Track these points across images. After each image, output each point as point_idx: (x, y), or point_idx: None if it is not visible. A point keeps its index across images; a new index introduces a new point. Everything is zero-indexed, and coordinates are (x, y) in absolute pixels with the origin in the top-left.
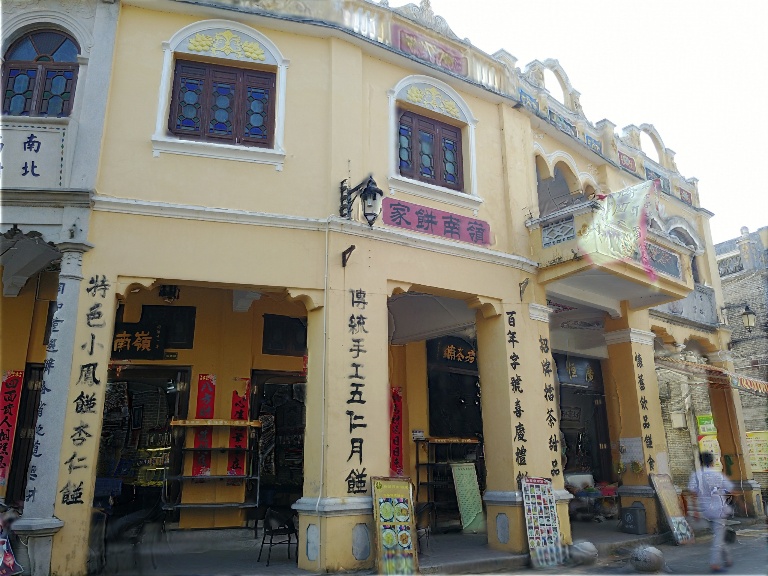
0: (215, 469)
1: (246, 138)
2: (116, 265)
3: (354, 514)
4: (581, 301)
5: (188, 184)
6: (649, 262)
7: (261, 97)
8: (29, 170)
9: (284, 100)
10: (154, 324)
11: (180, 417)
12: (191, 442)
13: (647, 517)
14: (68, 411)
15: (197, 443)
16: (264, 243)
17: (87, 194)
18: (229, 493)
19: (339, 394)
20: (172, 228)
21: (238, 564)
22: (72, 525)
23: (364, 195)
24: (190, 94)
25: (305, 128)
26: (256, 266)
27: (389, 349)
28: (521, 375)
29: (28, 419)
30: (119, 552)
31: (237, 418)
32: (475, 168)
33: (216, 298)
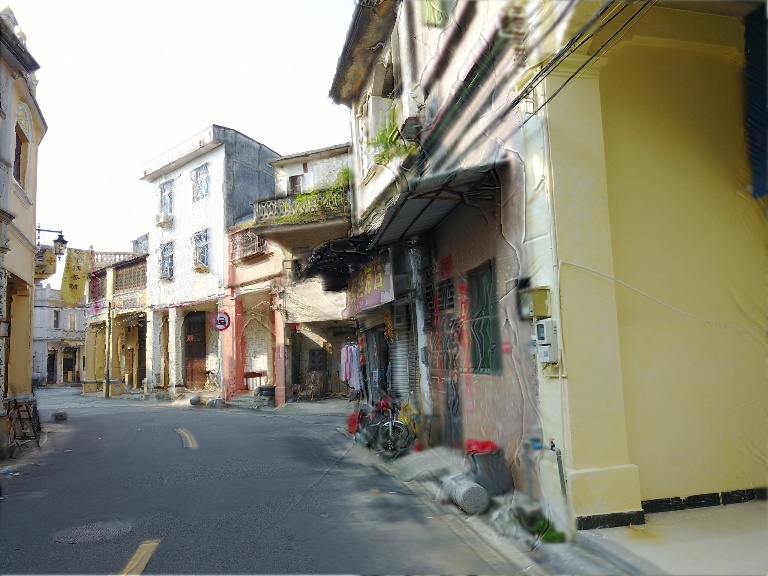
0: None
1: None
2: None
3: None
4: None
5: None
6: None
7: None
8: None
9: (28, 166)
10: None
11: None
12: None
13: None
14: None
15: None
16: None
17: None
18: None
19: None
20: (13, 242)
21: None
22: None
23: None
24: None
25: None
26: None
27: None
28: None
29: None
30: None
31: None
32: None
33: None
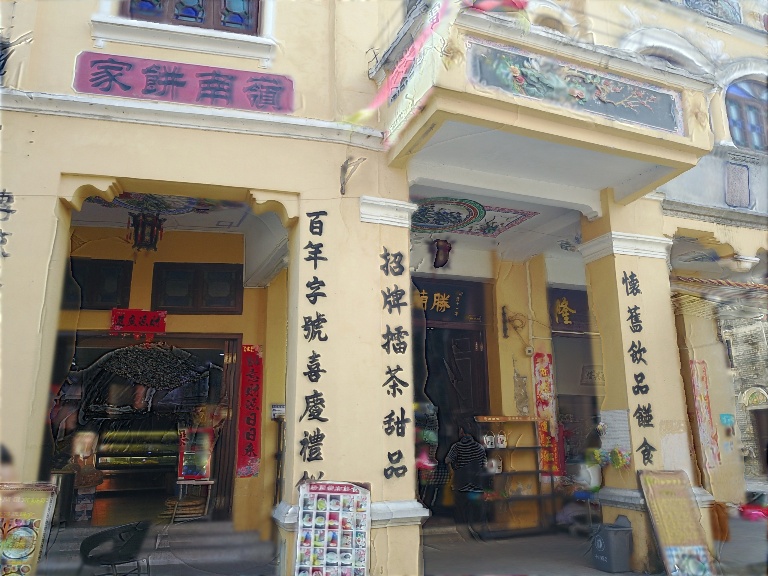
0: None
1: None
2: None
3: None
4: (508, 194)
5: None
6: (591, 105)
7: None
8: None
9: None
10: None
11: None
12: None
13: (634, 543)
14: None
15: None
16: None
17: None
18: None
19: None
20: None
21: None
22: None
23: None
24: None
25: None
26: None
27: (53, 280)
28: (327, 312)
29: None
30: None
31: None
32: None
33: None
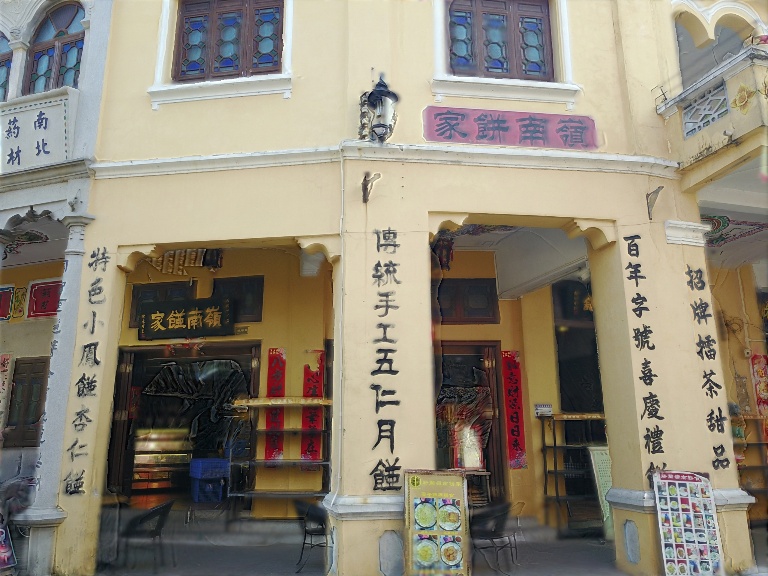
0: (288, 452)
1: (254, 69)
2: (116, 235)
3: (379, 518)
4: None
5: (187, 134)
6: None
7: (271, 18)
8: (41, 149)
9: (291, 13)
10: (224, 298)
11: (255, 395)
12: (263, 422)
13: None
14: (71, 395)
15: (269, 423)
16: (269, 187)
17: (83, 162)
18: (304, 479)
19: (360, 364)
20: (171, 186)
21: (273, 566)
22: (74, 516)
23: (370, 103)
24: (194, 34)
25: (317, 40)
26: (260, 216)
27: (434, 302)
28: (651, 325)
29: (122, 401)
30: (139, 545)
31: (310, 395)
32: (567, 46)
33: (284, 263)
